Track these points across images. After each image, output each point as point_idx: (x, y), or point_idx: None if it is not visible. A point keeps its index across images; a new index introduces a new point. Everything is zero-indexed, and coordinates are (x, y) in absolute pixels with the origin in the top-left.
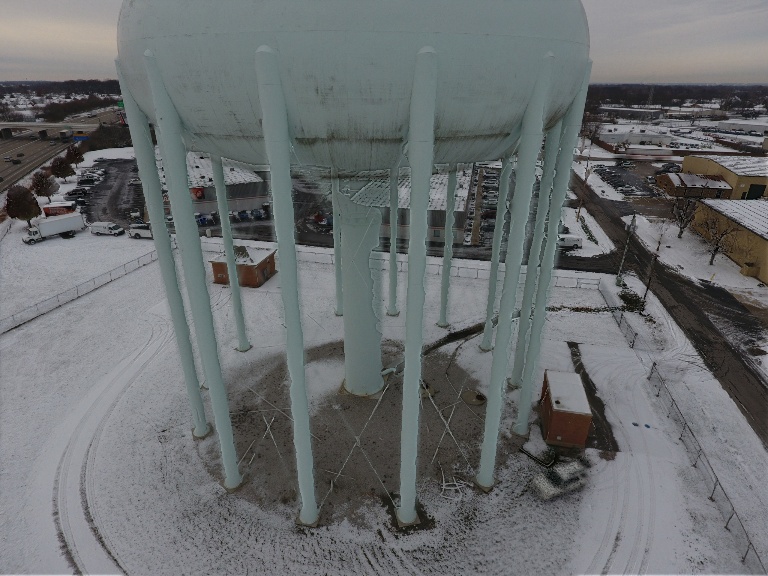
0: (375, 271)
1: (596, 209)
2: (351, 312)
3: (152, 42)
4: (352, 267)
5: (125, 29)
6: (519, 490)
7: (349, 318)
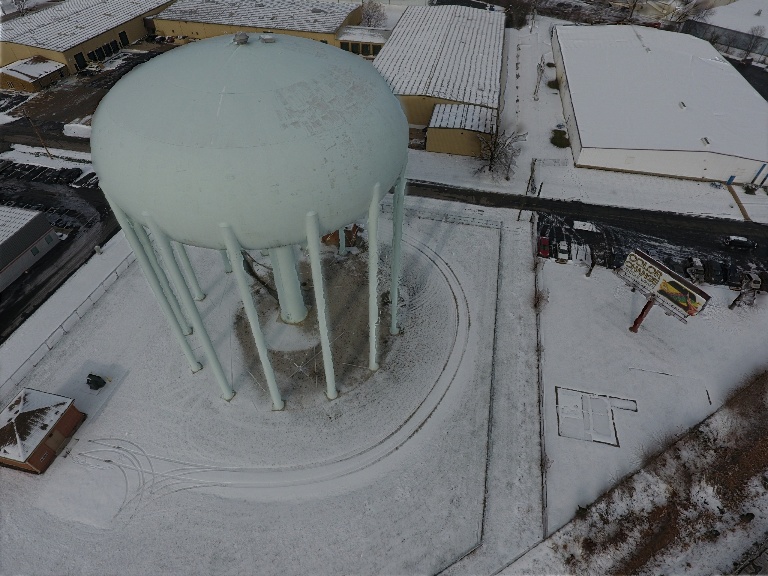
0: (96, 311)
1: (27, 139)
2: (295, 276)
3: (379, 177)
4: (292, 250)
5: (354, 184)
6: (380, 260)
7: (293, 281)
